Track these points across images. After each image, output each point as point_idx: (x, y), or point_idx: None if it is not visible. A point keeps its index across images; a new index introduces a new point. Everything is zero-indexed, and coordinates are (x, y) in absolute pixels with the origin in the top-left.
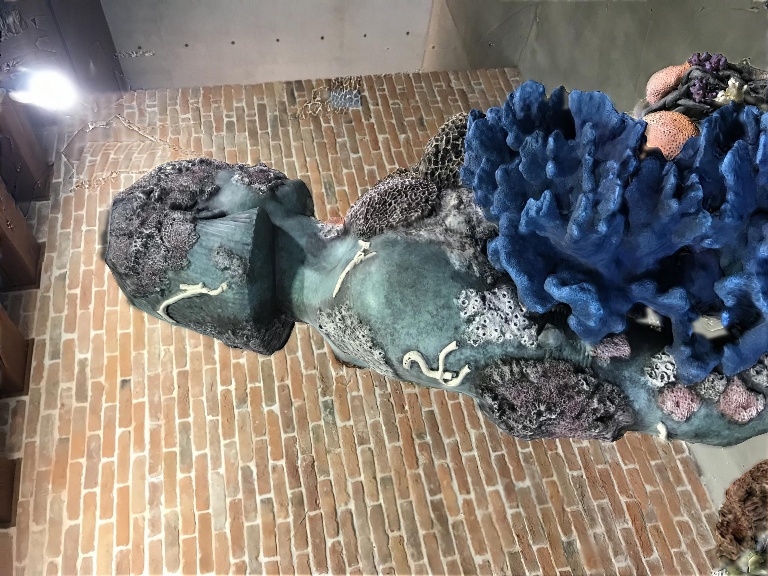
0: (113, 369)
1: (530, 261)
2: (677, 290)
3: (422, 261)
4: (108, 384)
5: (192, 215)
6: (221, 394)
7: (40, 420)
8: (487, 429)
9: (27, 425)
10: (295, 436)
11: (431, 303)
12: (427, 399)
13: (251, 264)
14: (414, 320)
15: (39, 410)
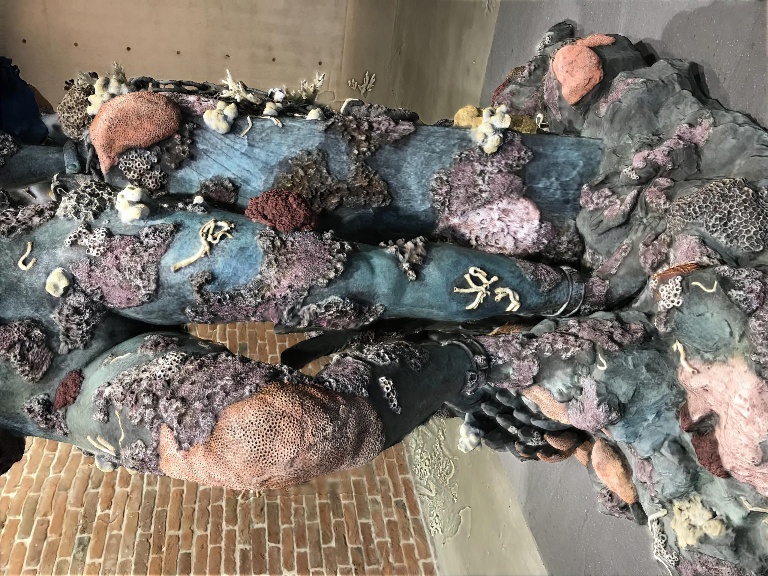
0: None
1: None
2: None
3: None
4: None
5: None
6: None
7: None
8: (241, 574)
9: None
10: (36, 570)
11: None
12: (188, 542)
13: None
14: None
15: None
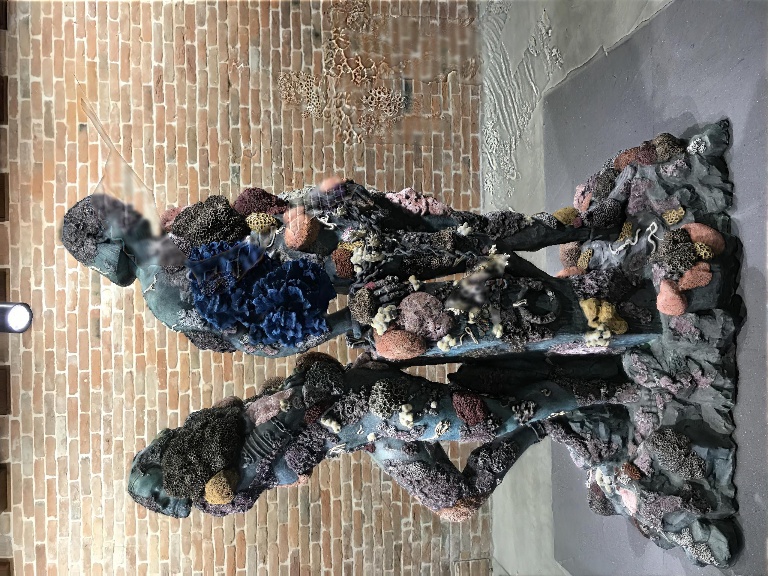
0: (73, 115)
1: (203, 305)
2: (246, 323)
3: (169, 297)
4: (69, 126)
5: (96, 242)
6: (156, 148)
7: (19, 145)
8: None
9: (9, 147)
10: (208, 189)
11: (170, 312)
12: (310, 177)
13: (118, 268)
14: (164, 315)
15: (17, 137)
